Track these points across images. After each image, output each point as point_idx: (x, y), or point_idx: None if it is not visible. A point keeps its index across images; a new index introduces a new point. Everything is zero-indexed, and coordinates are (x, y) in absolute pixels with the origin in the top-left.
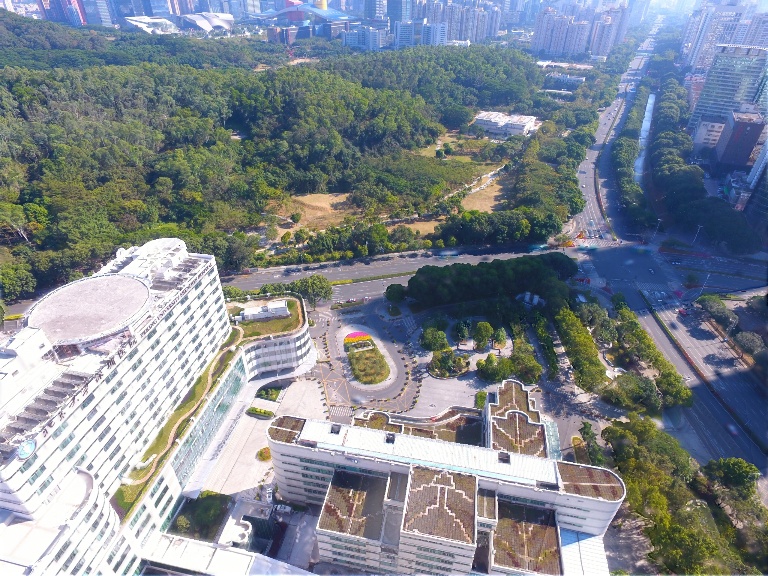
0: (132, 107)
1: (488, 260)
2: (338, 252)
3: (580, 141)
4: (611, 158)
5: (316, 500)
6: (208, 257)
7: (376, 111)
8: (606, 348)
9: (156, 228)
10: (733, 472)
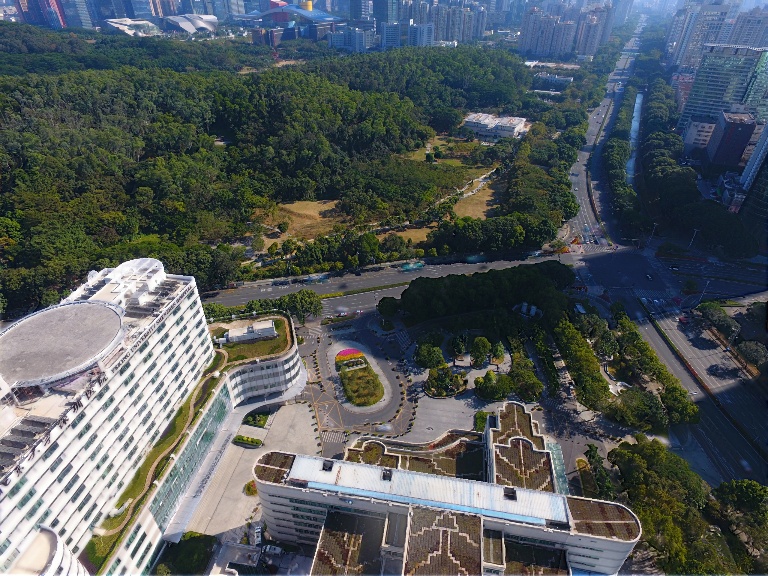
0: (111, 113)
1: (482, 268)
2: (327, 263)
3: (571, 143)
4: (602, 160)
5: (308, 540)
6: (187, 278)
7: (364, 114)
8: (607, 361)
9: (137, 240)
10: (747, 496)
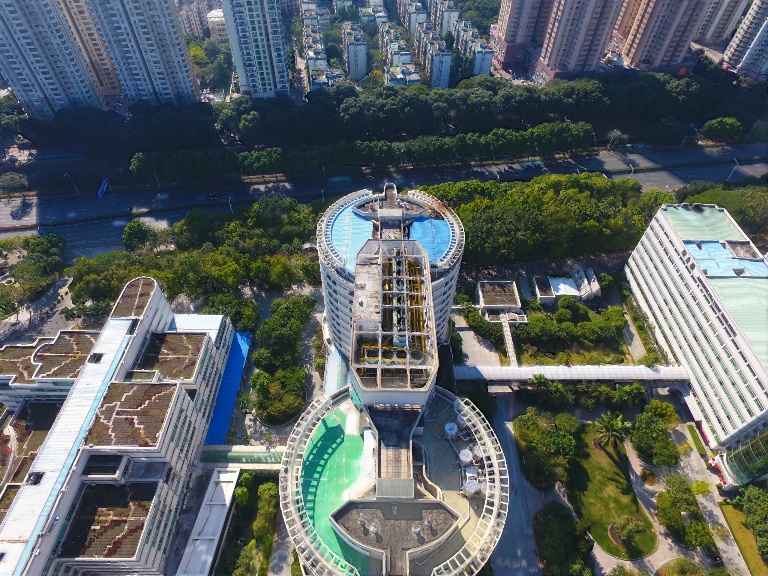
0: None
1: None
2: None
3: None
4: None
5: None
6: None
7: None
8: None
9: None
10: (136, 233)
